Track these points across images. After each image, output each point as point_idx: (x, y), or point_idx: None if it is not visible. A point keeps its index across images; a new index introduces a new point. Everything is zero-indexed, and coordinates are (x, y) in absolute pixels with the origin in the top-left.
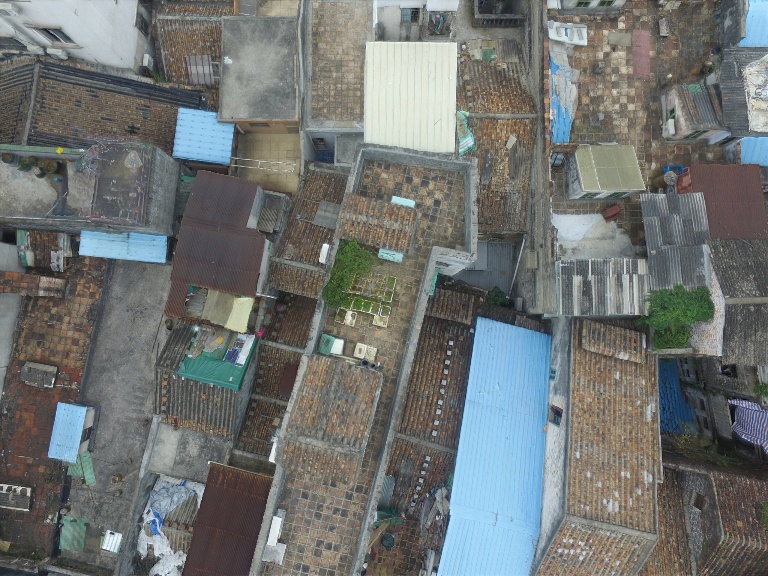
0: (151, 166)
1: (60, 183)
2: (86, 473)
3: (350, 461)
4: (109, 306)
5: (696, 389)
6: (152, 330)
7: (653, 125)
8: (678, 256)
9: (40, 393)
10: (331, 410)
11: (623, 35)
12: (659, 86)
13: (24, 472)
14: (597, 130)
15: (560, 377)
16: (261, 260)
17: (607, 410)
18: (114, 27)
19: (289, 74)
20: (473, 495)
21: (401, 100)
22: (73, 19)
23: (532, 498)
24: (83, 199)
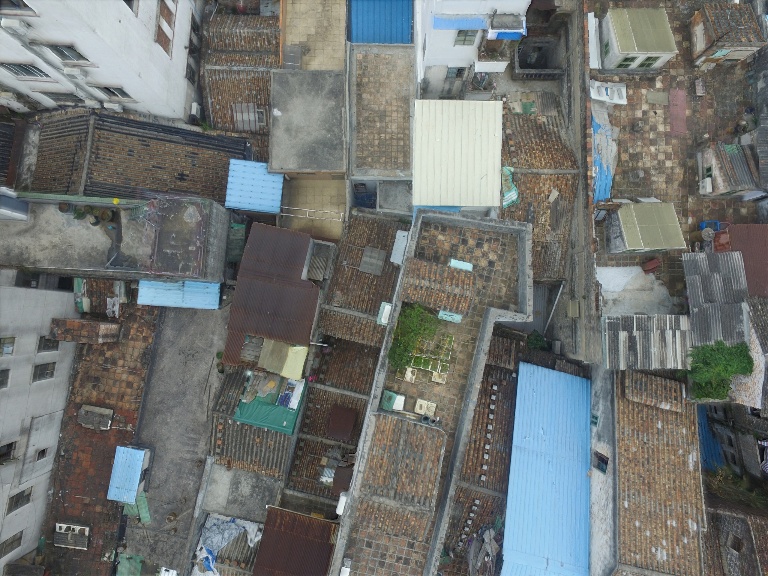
0: (209, 220)
1: (114, 231)
2: (141, 512)
3: (420, 518)
4: (161, 349)
5: (724, 426)
6: (204, 373)
7: (689, 181)
8: (719, 313)
9: (96, 435)
10: (400, 469)
11: (661, 94)
12: (695, 143)
13: (81, 512)
14: (636, 185)
15: (603, 424)
16: (315, 311)
17: (651, 459)
18: (169, 82)
19: (337, 126)
20: (524, 540)
21: (449, 156)
22: (136, 81)
23: (580, 542)
24: (137, 246)
